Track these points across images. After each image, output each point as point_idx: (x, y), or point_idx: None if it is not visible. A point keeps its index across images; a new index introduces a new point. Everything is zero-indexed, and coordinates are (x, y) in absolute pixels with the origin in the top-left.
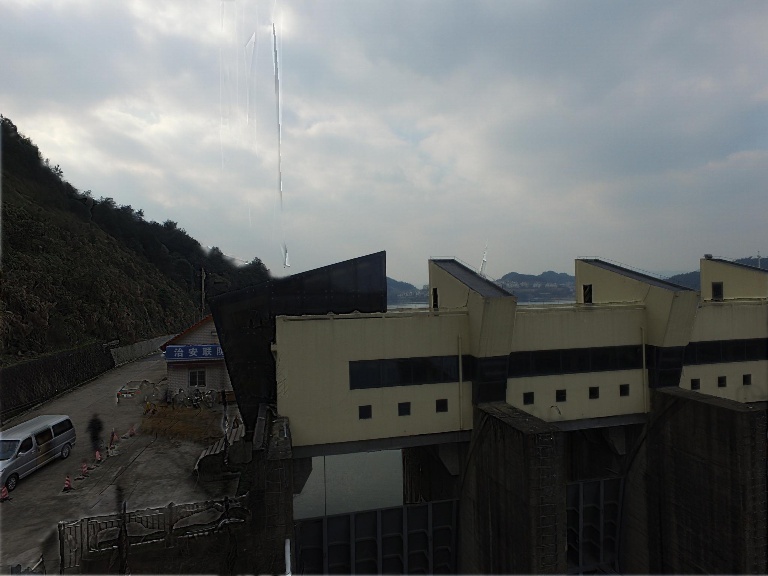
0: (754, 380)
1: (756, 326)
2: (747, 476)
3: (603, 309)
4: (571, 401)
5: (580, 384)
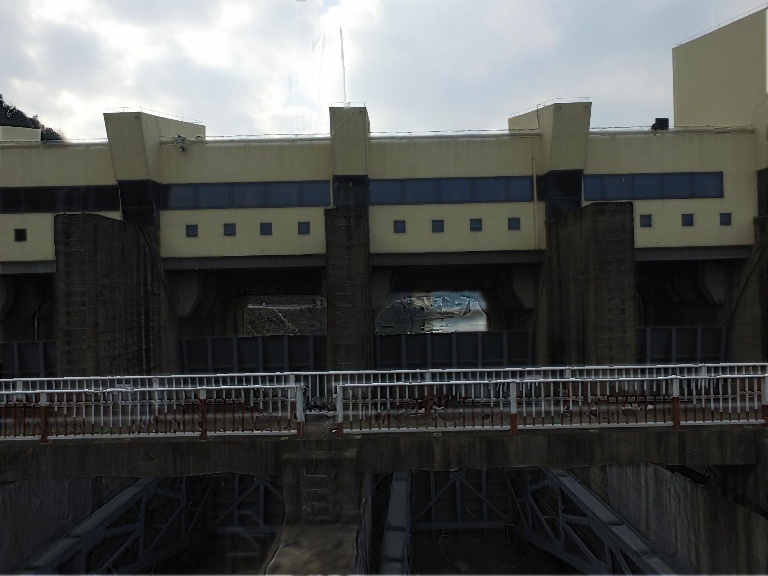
0: (277, 230)
1: (281, 167)
2: (60, 287)
3: (75, 146)
4: (33, 241)
5: (44, 224)
